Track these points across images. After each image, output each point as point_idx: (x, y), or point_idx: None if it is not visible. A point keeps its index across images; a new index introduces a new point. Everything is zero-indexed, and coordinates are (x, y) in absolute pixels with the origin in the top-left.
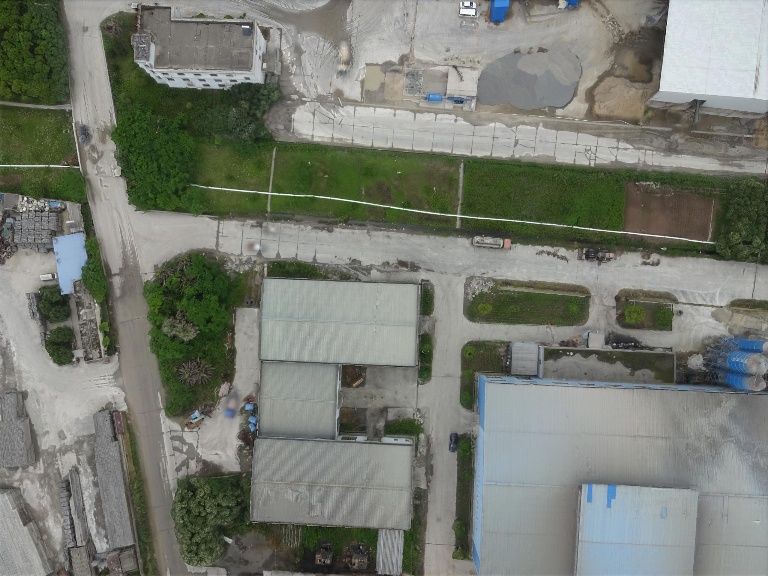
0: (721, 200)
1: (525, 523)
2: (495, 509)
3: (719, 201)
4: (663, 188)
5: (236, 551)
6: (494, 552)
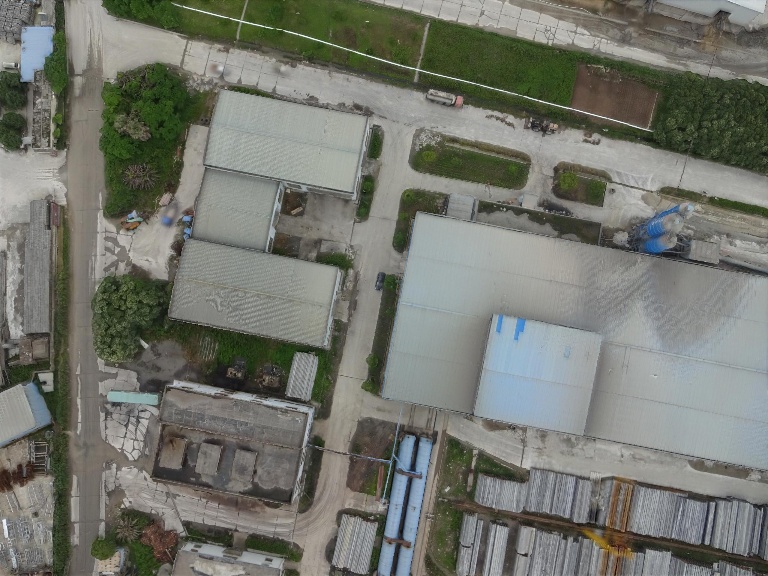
0: (664, 93)
1: (434, 347)
2: (407, 330)
3: (662, 94)
4: (612, 72)
5: (150, 356)
6: (400, 372)
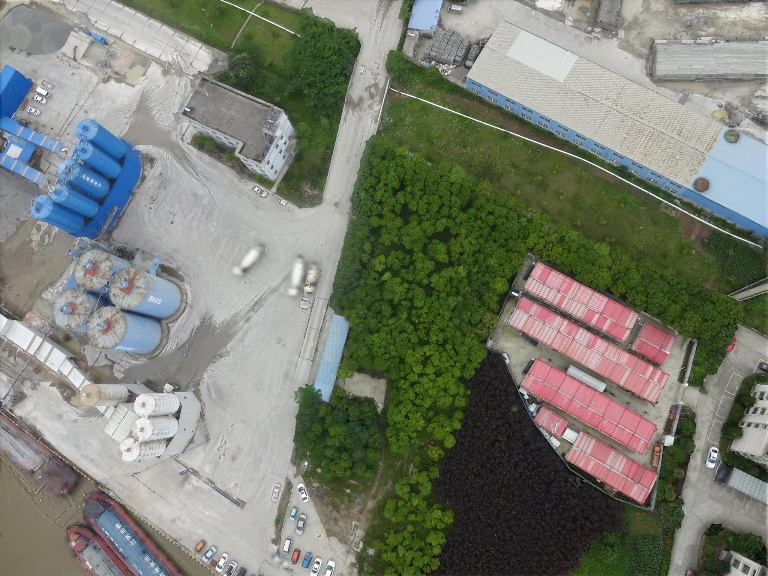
0: None
1: None
2: None
3: None
4: None
5: None
6: None
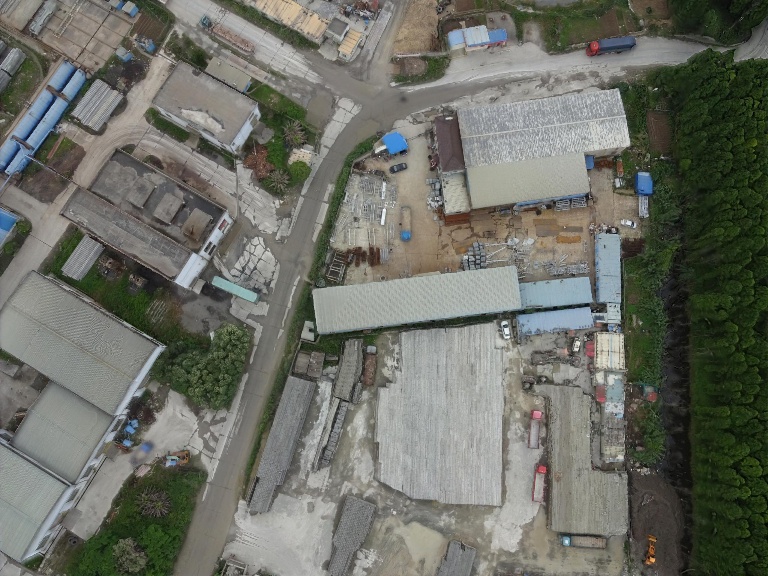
0: None
1: None
2: None
3: None
4: None
5: (212, 323)
6: None
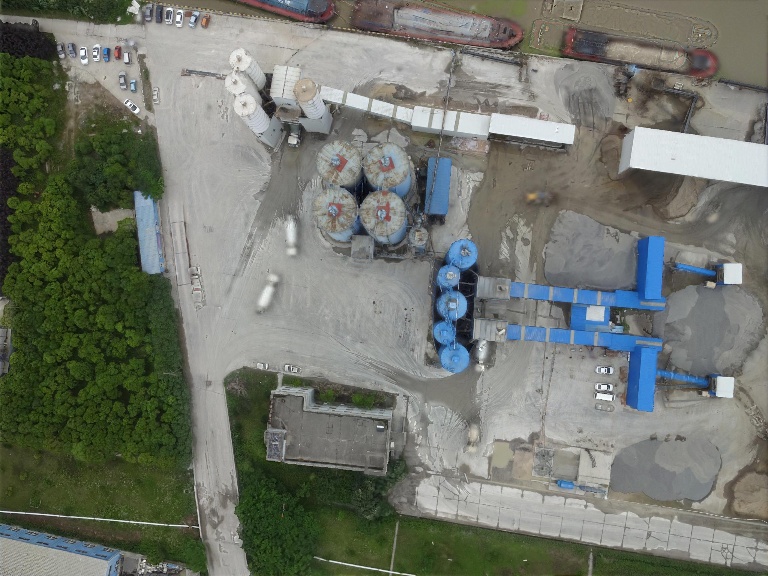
0: None
1: None
2: None
3: None
4: None
5: None
6: None
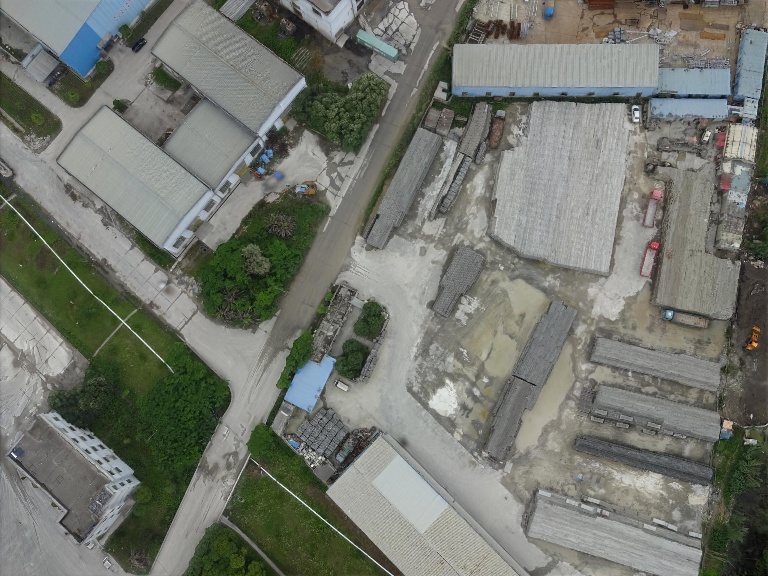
0: None
1: None
2: None
3: None
4: None
5: (351, 75)
6: None
